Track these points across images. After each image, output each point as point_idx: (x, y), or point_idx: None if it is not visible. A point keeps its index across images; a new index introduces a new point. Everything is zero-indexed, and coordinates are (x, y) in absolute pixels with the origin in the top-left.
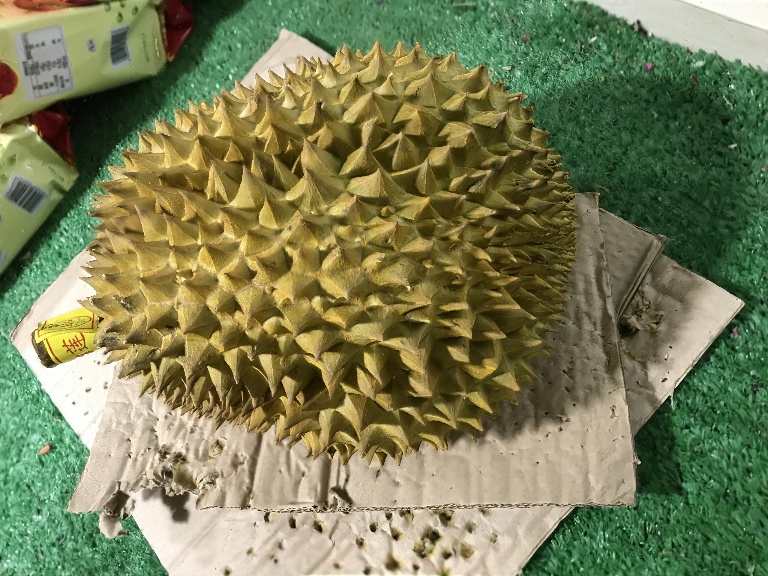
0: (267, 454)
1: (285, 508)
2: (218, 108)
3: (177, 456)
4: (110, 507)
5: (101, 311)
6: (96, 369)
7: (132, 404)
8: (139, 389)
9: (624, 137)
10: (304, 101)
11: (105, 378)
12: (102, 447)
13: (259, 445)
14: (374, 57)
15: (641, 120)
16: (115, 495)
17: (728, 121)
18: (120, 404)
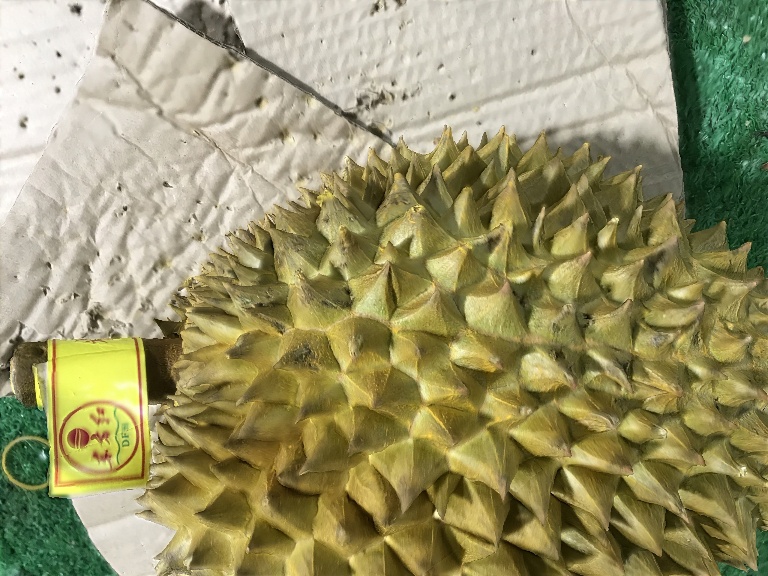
0: None
1: None
2: (546, 363)
3: (114, 336)
4: (4, 361)
5: (181, 522)
6: (14, 83)
7: (66, 209)
8: (84, 195)
9: None
10: (654, 439)
11: (26, 109)
12: (6, 258)
13: None
14: None
15: None
16: (13, 343)
17: None
18: (48, 200)
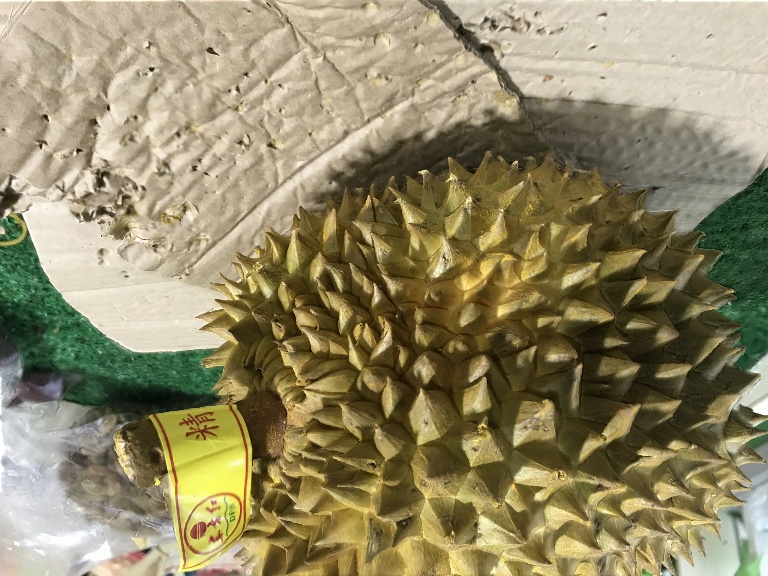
0: (231, 246)
1: (213, 290)
2: (592, 572)
3: (123, 197)
4: None
5: None
6: None
7: (72, 58)
8: (100, 48)
9: (745, 252)
10: None
11: None
12: None
13: (229, 232)
14: (709, 527)
15: (767, 254)
16: (4, 196)
17: (760, 291)
18: (48, 48)
